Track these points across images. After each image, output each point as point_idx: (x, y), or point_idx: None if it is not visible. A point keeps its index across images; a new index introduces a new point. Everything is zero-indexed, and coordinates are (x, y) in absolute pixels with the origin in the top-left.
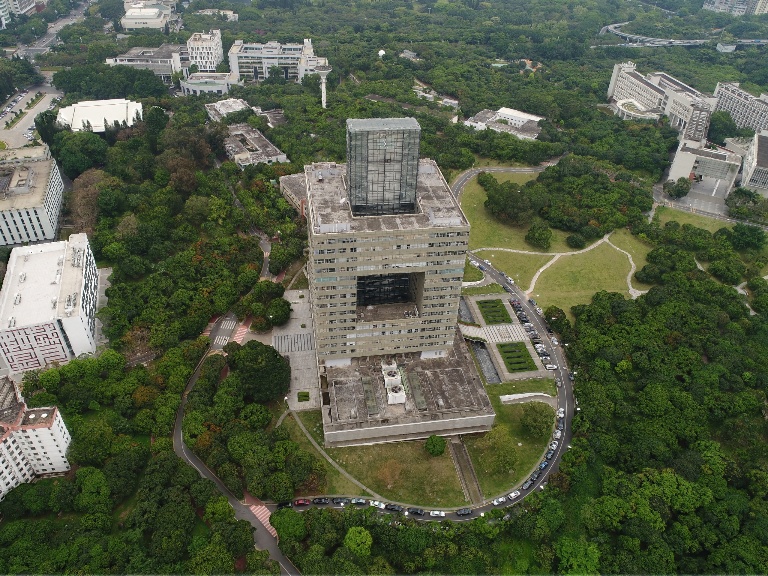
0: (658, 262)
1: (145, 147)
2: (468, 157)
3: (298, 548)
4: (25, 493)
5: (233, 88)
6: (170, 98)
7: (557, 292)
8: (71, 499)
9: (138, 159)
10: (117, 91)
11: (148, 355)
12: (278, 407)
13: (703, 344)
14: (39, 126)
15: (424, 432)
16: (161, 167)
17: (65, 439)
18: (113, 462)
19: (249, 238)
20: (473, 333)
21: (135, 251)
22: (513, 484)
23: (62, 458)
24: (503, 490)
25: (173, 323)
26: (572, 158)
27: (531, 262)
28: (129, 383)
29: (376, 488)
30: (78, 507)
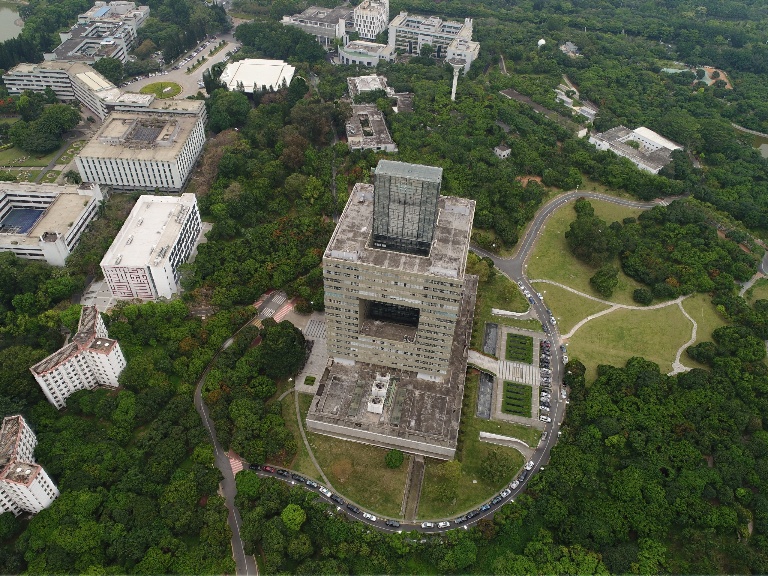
0: (721, 342)
1: (280, 114)
2: (574, 178)
3: (246, 505)
4: (82, 397)
5: (381, 62)
6: (323, 65)
7: (594, 345)
8: (109, 412)
9: (270, 125)
10: (281, 51)
11: (209, 309)
12: (286, 384)
13: (714, 444)
14: (205, 79)
15: (391, 444)
16: (281, 139)
17: (120, 364)
18: (145, 393)
19: (325, 224)
20: (486, 364)
21: (233, 214)
22: (448, 515)
23: (116, 378)
24: (437, 517)
25: (233, 289)
26: (687, 202)
27: (584, 307)
28: (181, 332)
29: (331, 478)
30: (112, 419)
